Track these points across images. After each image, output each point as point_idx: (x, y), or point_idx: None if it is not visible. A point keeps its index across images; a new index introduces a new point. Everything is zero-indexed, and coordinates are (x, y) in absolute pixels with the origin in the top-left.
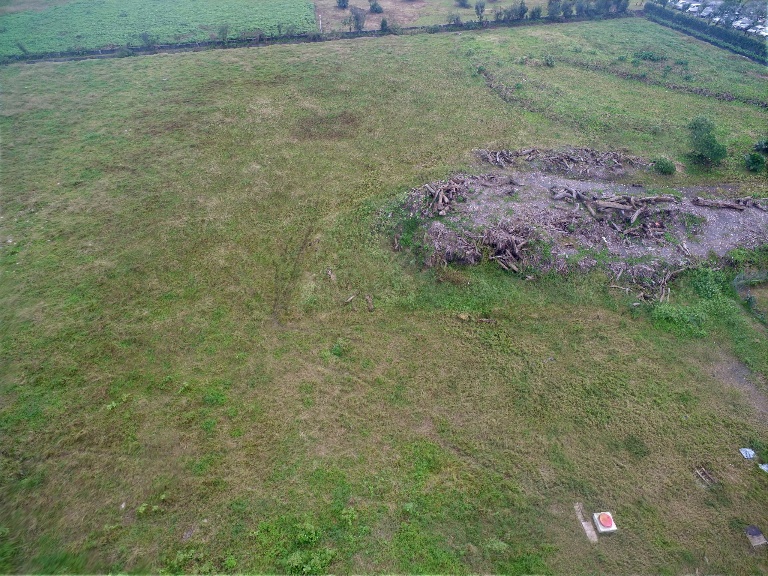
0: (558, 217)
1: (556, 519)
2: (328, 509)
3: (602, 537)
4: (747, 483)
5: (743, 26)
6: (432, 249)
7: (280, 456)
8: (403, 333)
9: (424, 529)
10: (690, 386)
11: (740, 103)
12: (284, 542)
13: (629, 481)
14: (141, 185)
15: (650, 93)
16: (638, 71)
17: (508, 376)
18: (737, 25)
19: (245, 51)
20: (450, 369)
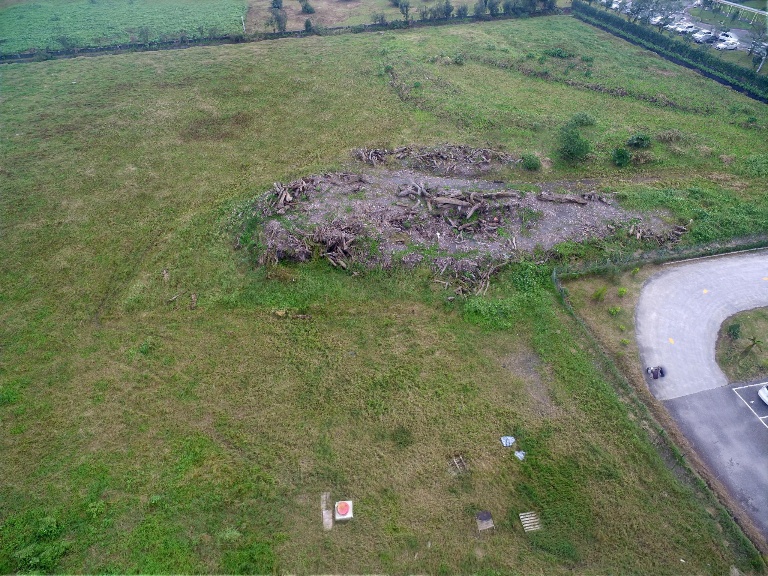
0: (395, 214)
1: (298, 508)
2: (79, 503)
3: (337, 525)
4: (496, 470)
5: (662, 22)
6: (265, 247)
7: (51, 452)
8: (216, 330)
9: (167, 520)
10: (477, 377)
11: (632, 99)
12: (24, 536)
13: (383, 470)
14: (11, 188)
15: (548, 90)
16: (542, 68)
17: (303, 370)
18: (657, 21)
19: (163, 53)
20: (248, 365)
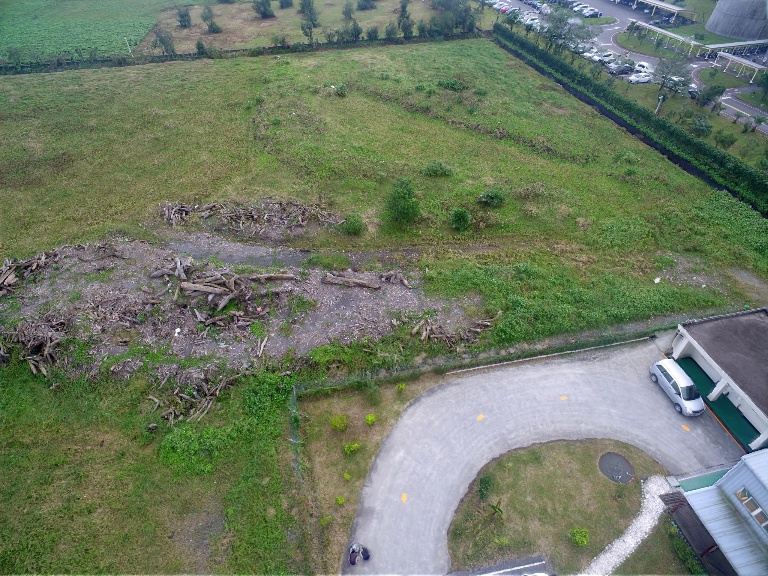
0: (132, 303)
1: None
2: None
3: None
4: None
5: None
6: None
7: None
8: None
9: None
10: (125, 555)
11: (510, 142)
12: None
13: None
14: None
15: (422, 129)
16: (425, 103)
17: None
18: None
19: (31, 78)
20: None
